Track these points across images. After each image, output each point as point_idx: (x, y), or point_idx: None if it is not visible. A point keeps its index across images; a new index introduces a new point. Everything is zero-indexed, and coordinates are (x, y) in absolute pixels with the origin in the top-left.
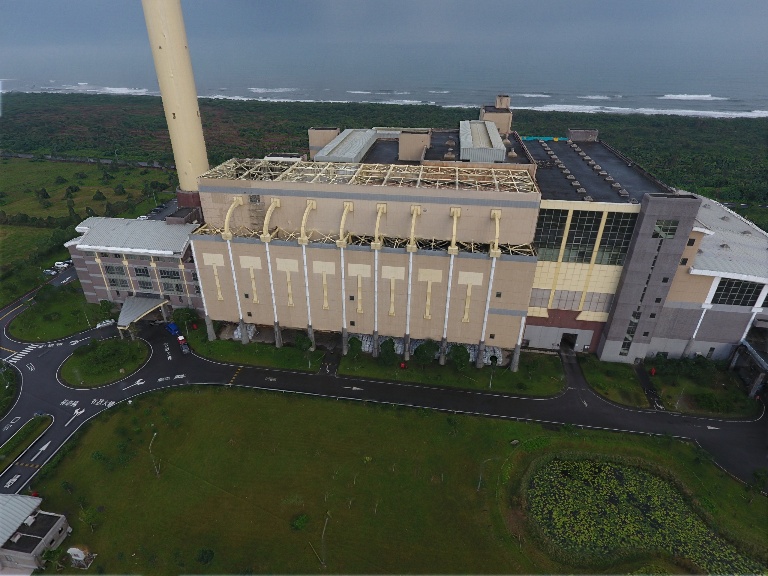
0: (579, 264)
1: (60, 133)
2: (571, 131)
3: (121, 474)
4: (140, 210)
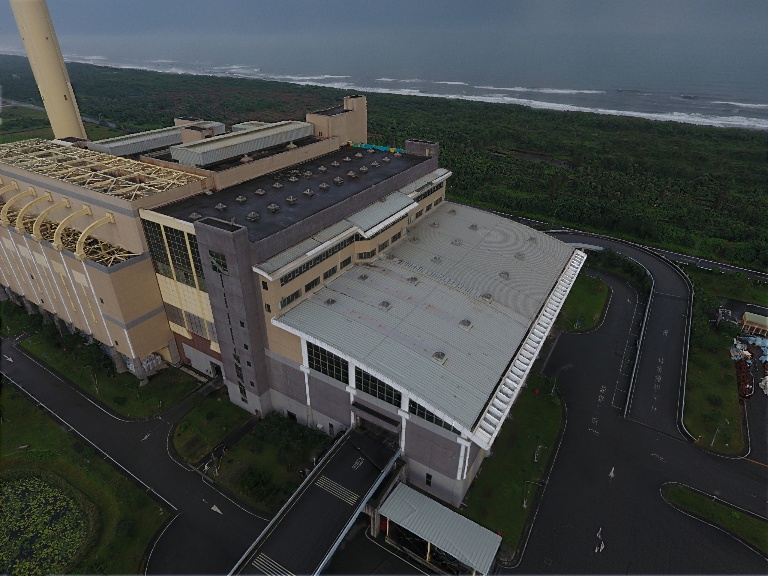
0: (189, 287)
1: (167, 109)
2: (406, 142)
3: None
4: None
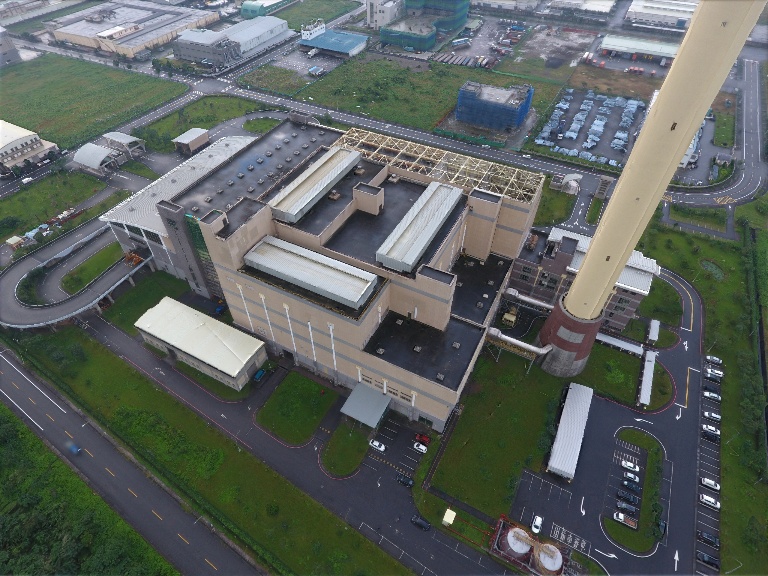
0: None
1: None
2: None
3: None
4: (744, 551)
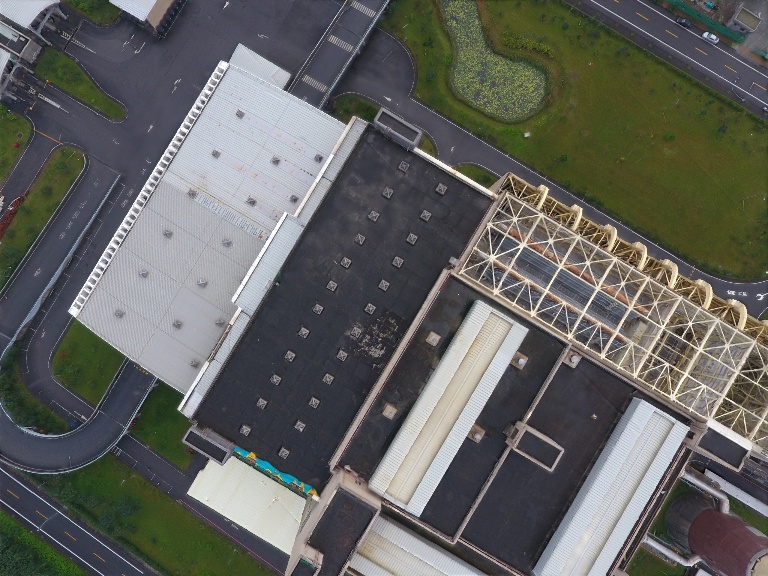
0: None
1: None
2: (229, 450)
3: (765, 208)
4: None
